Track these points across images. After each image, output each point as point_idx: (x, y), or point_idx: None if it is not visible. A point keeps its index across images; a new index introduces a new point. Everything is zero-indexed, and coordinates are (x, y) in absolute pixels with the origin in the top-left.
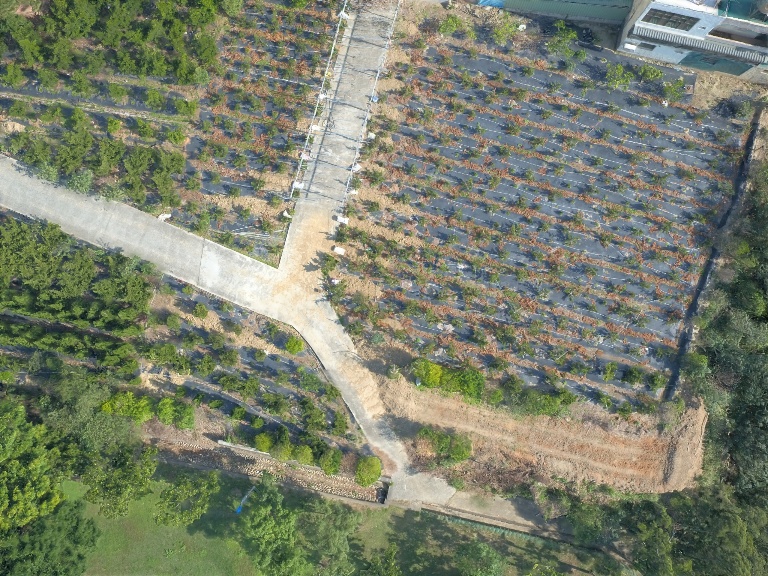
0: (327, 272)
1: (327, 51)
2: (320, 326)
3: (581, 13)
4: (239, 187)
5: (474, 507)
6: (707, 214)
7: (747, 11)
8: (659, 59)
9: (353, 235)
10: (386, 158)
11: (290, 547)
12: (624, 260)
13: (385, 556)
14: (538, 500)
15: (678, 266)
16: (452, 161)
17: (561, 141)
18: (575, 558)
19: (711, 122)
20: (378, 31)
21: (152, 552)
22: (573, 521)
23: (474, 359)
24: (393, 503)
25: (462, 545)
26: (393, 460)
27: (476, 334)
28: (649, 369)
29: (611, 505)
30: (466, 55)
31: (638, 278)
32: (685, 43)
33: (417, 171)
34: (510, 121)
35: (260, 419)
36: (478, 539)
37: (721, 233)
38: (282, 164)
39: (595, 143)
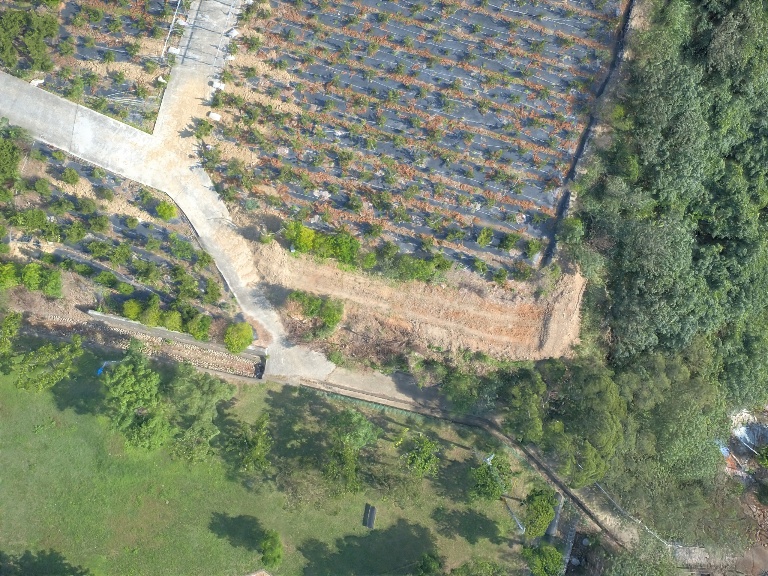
0: (200, 136)
1: None
2: (194, 193)
3: None
4: (114, 52)
5: (354, 383)
6: (585, 83)
7: None
8: None
9: (229, 101)
10: (264, 24)
11: (152, 408)
12: (501, 127)
13: (256, 425)
14: (414, 369)
15: (556, 134)
16: (331, 28)
17: (440, 9)
18: (456, 435)
19: None
20: None
21: (21, 428)
22: (449, 390)
23: (350, 226)
24: (271, 378)
25: (337, 415)
26: (268, 331)
27: (352, 200)
28: (527, 237)
29: (489, 376)
30: None
31: (516, 146)
32: None
33: (293, 35)
34: None
35: (130, 285)
36: None
37: None
38: (156, 27)
39: (474, 12)
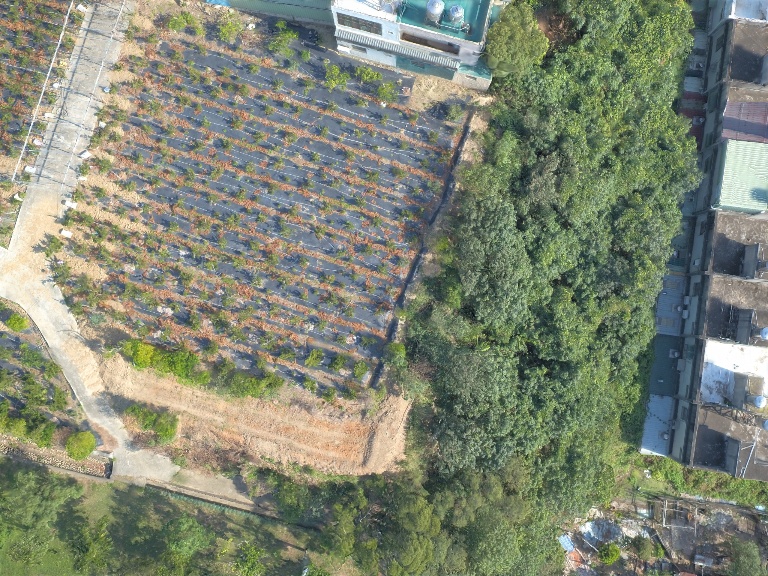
0: (50, 254)
1: (64, 42)
2: (46, 305)
3: (303, 15)
4: None
5: (197, 485)
6: (418, 211)
7: (423, 18)
8: (379, 62)
9: (81, 219)
10: (116, 147)
11: None
12: (336, 252)
13: (95, 527)
14: (245, 478)
15: (388, 260)
16: (179, 152)
17: (283, 136)
18: (292, 536)
19: (425, 123)
20: (114, 25)
21: None
22: (279, 500)
23: (191, 342)
24: (118, 478)
25: None
26: (113, 436)
27: (192, 318)
28: (357, 357)
29: (319, 486)
30: (197, 51)
31: (350, 270)
32: (383, 47)
33: (141, 160)
34: (235, 116)
35: None
36: (198, 515)
37: (431, 230)
38: (12, 149)
39: (315, 139)
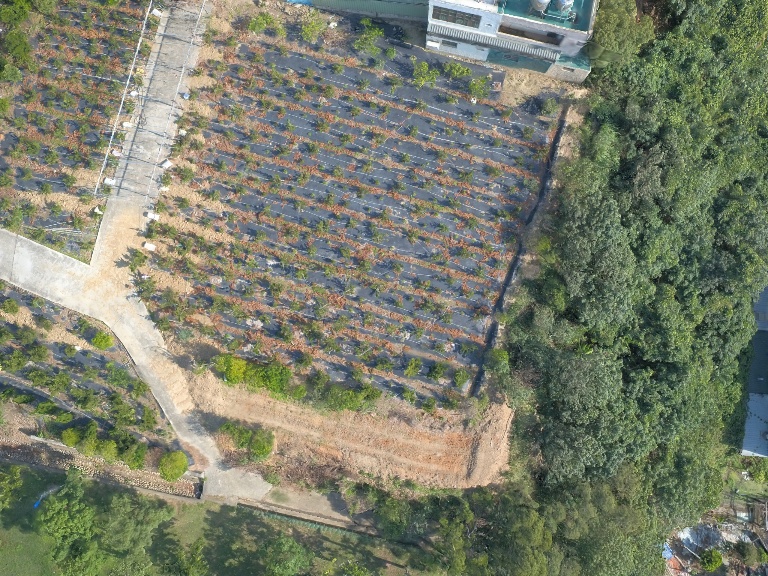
0: (135, 268)
1: (140, 48)
2: (131, 322)
3: (388, 11)
4: (52, 183)
5: (290, 502)
6: (514, 211)
7: (526, 8)
8: (468, 56)
9: (164, 231)
10: (197, 155)
11: (86, 541)
12: (431, 256)
13: (191, 551)
14: (344, 495)
15: (485, 262)
16: (263, 158)
17: (370, 138)
18: (390, 553)
19: (519, 119)
20: (191, 28)
21: None
22: (380, 516)
23: (282, 355)
24: (209, 498)
25: (270, 540)
26: (204, 455)
27: (283, 330)
28: (456, 365)
29: (420, 500)
30: (277, 52)
31: (445, 274)
32: (478, 40)
33: (225, 168)
34: (320, 118)
35: (68, 414)
36: (293, 534)
37: (528, 230)
38: (91, 161)
39: (404, 140)
